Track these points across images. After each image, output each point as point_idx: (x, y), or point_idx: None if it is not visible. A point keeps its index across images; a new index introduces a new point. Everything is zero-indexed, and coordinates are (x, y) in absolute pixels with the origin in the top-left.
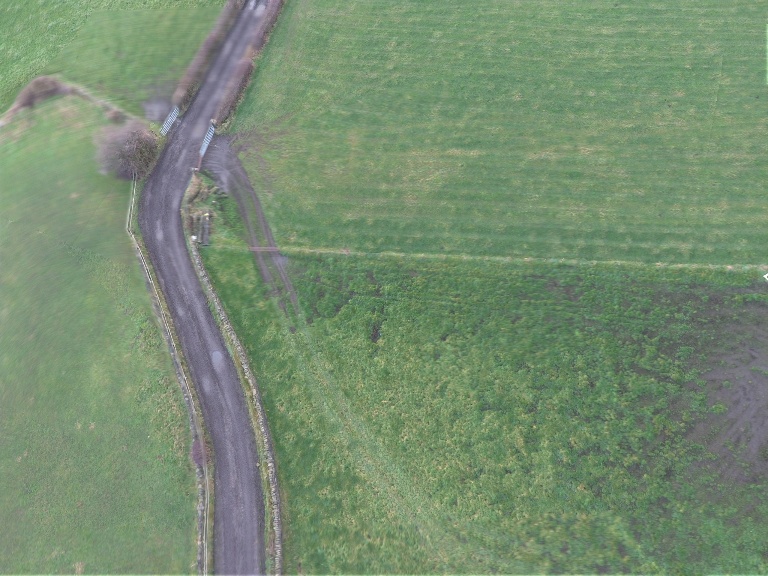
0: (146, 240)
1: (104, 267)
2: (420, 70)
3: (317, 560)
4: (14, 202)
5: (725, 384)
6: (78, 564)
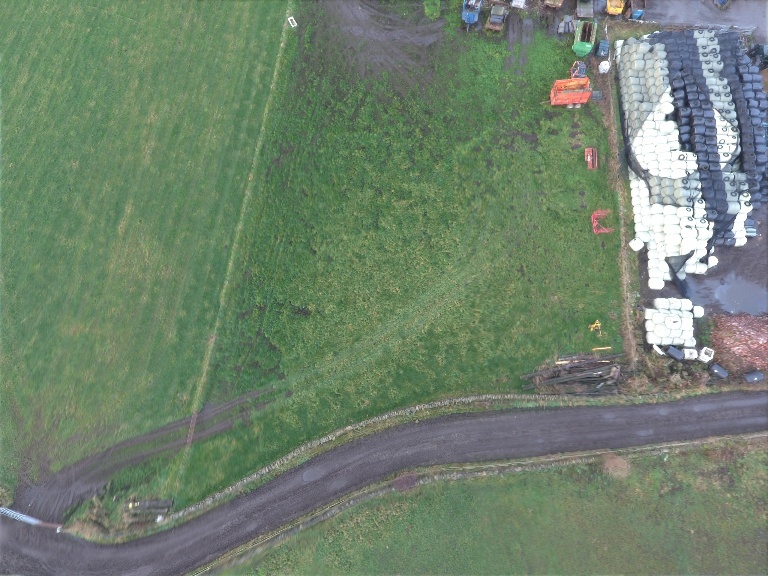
0: None
1: None
2: (4, 252)
3: (493, 366)
4: None
5: (369, 68)
6: None
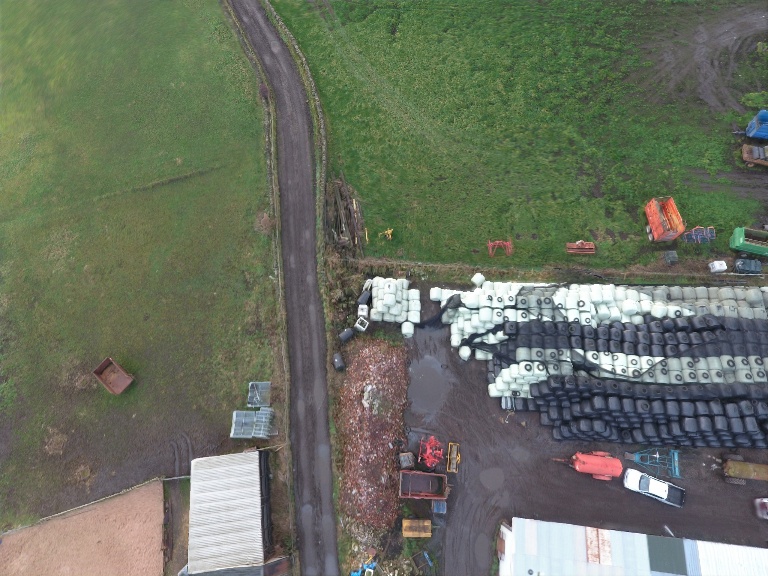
0: None
1: None
2: None
3: (352, 154)
4: None
5: (654, 50)
6: (178, 158)
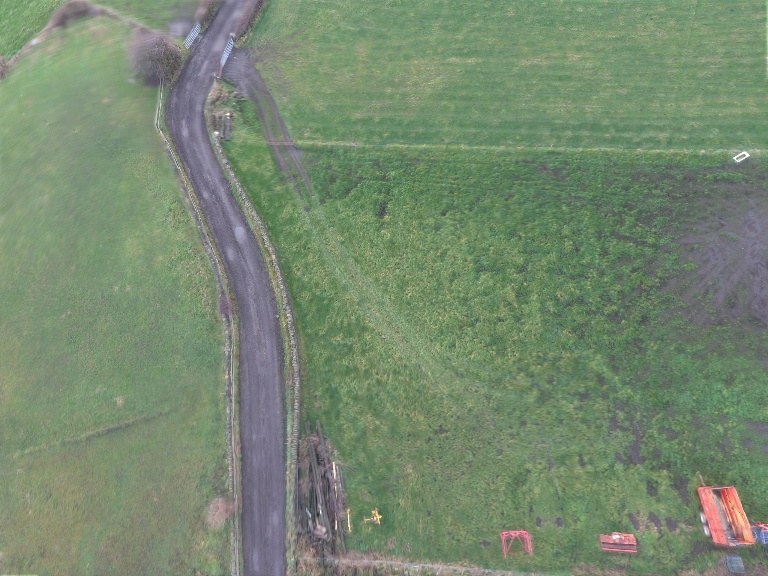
0: (173, 136)
1: (135, 159)
2: None
3: (331, 393)
4: (51, 107)
5: (696, 247)
6: (119, 398)
